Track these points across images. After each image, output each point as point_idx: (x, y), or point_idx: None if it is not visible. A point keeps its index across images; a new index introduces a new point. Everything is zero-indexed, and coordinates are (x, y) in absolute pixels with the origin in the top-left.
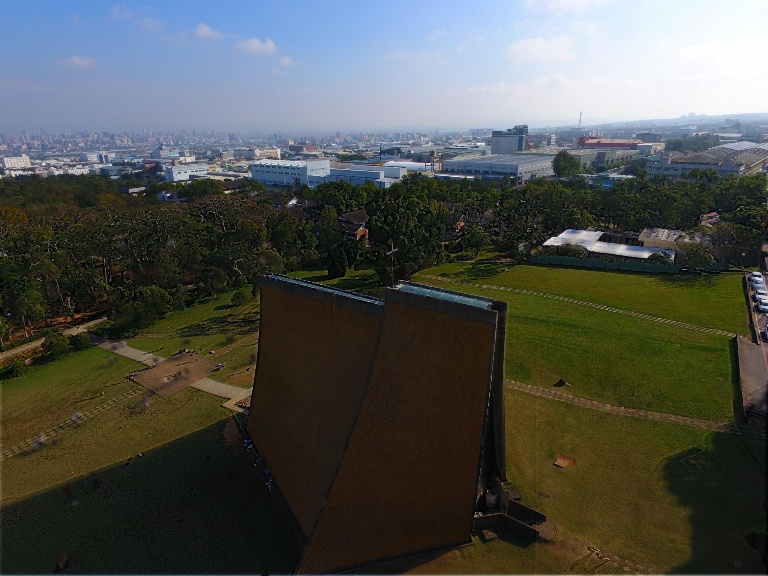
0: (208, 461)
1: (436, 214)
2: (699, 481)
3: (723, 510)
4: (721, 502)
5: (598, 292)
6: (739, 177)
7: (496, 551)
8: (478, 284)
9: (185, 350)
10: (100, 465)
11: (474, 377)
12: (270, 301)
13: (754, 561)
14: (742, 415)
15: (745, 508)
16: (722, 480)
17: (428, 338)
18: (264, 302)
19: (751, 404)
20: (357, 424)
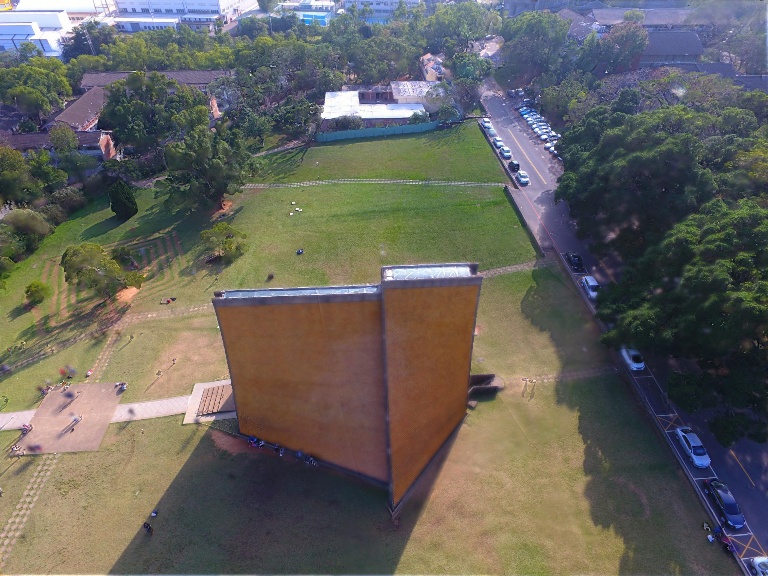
0: (234, 478)
1: (192, 101)
2: (545, 308)
3: (564, 321)
4: (561, 317)
5: (396, 166)
6: (435, 13)
7: (483, 411)
8: (293, 183)
9: (49, 388)
10: (118, 550)
11: (465, 321)
12: (234, 319)
13: (590, 344)
14: (541, 252)
15: (572, 315)
16: (554, 302)
17: (427, 307)
18: (225, 321)
19: (541, 242)
20: (389, 389)
